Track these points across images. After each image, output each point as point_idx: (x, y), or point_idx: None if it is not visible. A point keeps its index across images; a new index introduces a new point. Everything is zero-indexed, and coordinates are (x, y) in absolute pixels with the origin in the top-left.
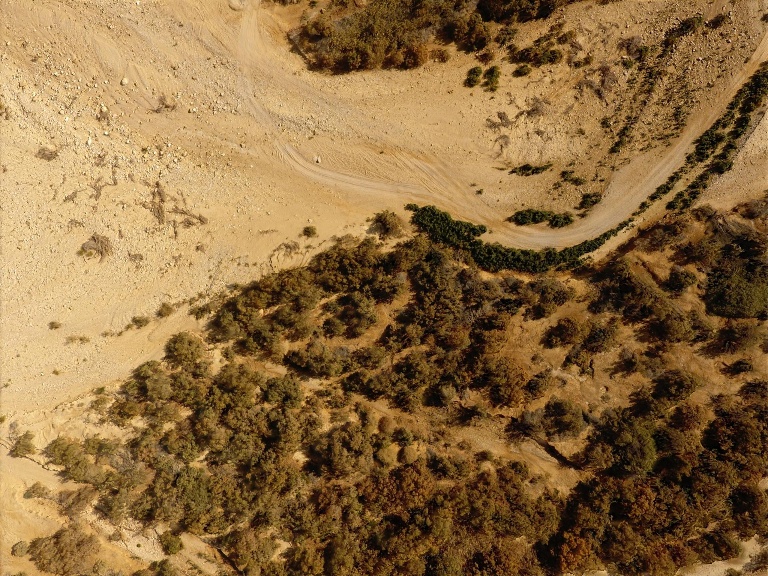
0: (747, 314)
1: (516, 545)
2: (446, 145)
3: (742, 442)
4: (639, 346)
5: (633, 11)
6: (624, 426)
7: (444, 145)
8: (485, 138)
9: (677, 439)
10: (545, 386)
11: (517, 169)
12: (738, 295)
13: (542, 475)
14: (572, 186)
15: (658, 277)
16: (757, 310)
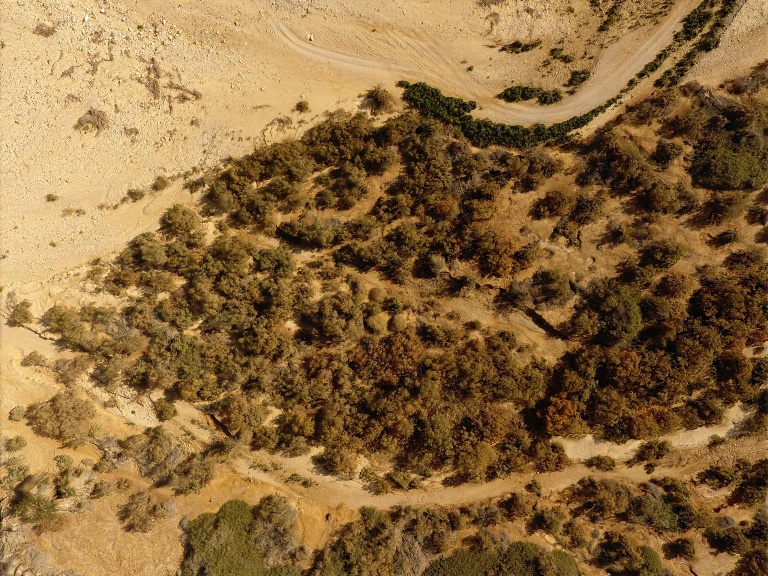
0: (732, 184)
1: (503, 410)
2: (437, 23)
3: (726, 308)
4: (626, 218)
5: None
6: (610, 293)
7: (435, 23)
8: (476, 16)
9: (662, 305)
10: (533, 254)
11: (507, 46)
12: (723, 165)
13: (530, 345)
14: (561, 63)
15: (645, 150)
16: (742, 180)
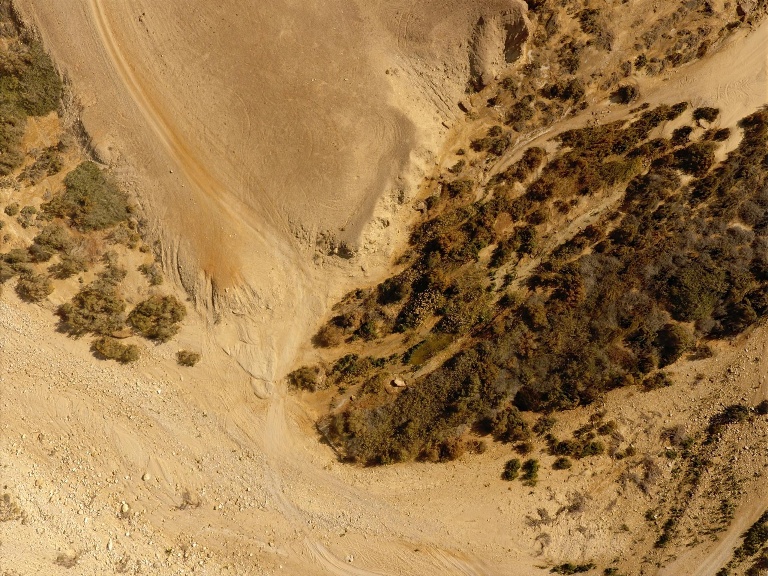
0: None
1: None
2: (484, 543)
3: None
4: None
5: (676, 399)
6: None
7: (482, 543)
8: (525, 536)
9: None
10: None
11: (559, 568)
12: None
13: None
14: None
15: None
16: None
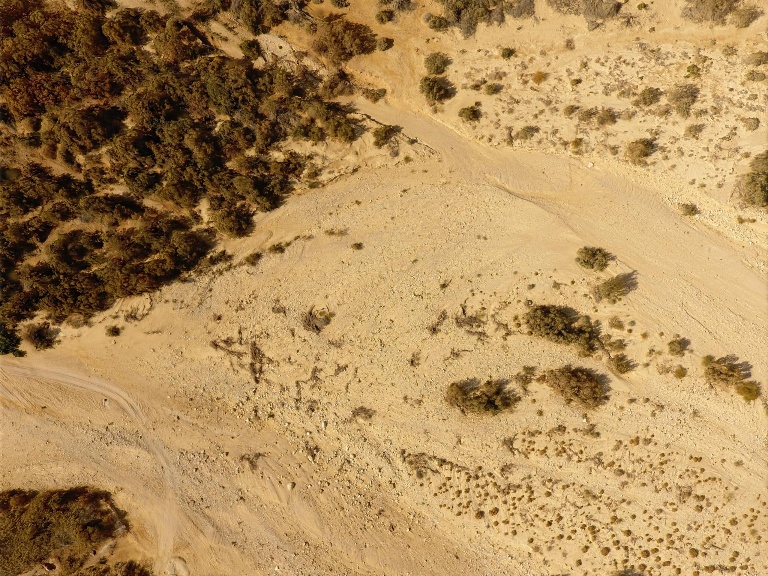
0: None
1: None
2: None
3: None
4: None
5: None
6: None
7: None
8: None
9: None
10: None
11: None
12: None
13: None
14: None
15: None
16: None
